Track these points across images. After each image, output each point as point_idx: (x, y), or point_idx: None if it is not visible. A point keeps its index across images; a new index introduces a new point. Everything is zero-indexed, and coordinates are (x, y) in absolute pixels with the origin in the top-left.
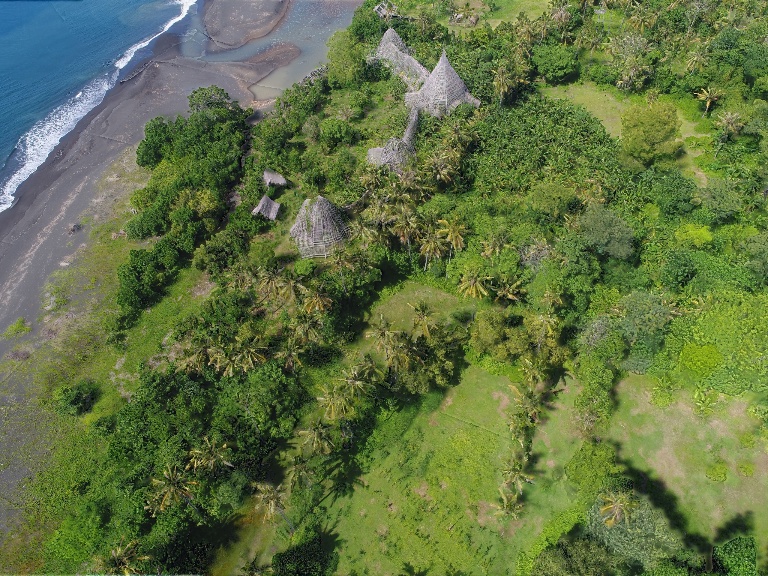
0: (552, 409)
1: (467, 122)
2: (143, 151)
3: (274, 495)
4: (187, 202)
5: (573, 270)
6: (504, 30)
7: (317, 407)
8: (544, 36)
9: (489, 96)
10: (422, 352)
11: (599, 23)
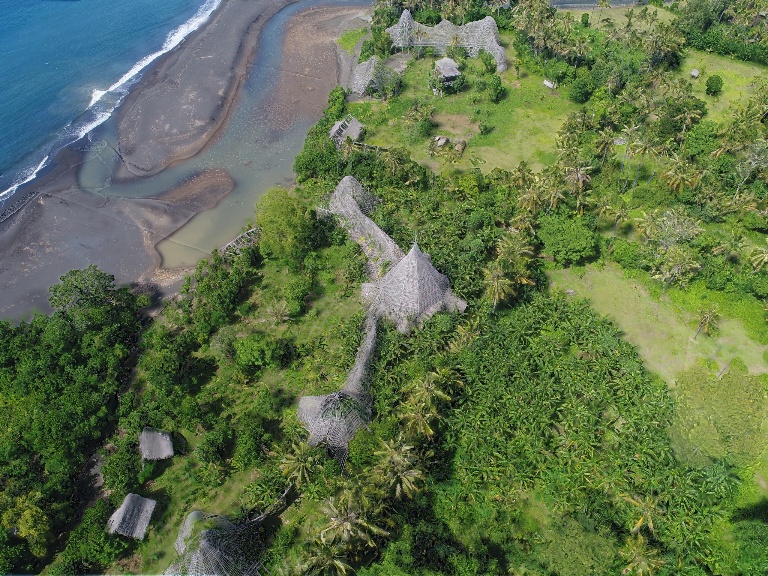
0: None
1: (447, 345)
2: None
3: None
4: (3, 511)
5: None
6: (499, 179)
7: None
8: (554, 206)
9: (478, 288)
10: None
11: (623, 173)
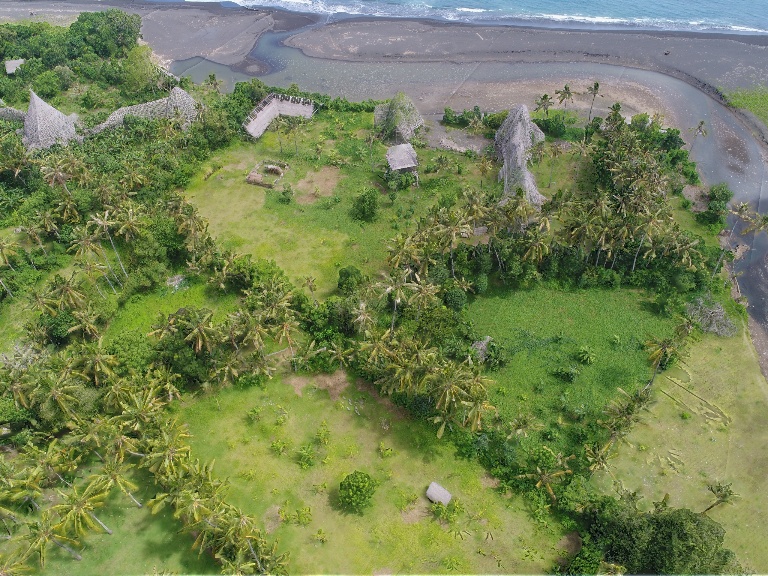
0: None
1: None
2: (81, 14)
3: None
4: None
5: None
6: None
7: None
8: None
9: None
10: None
11: None
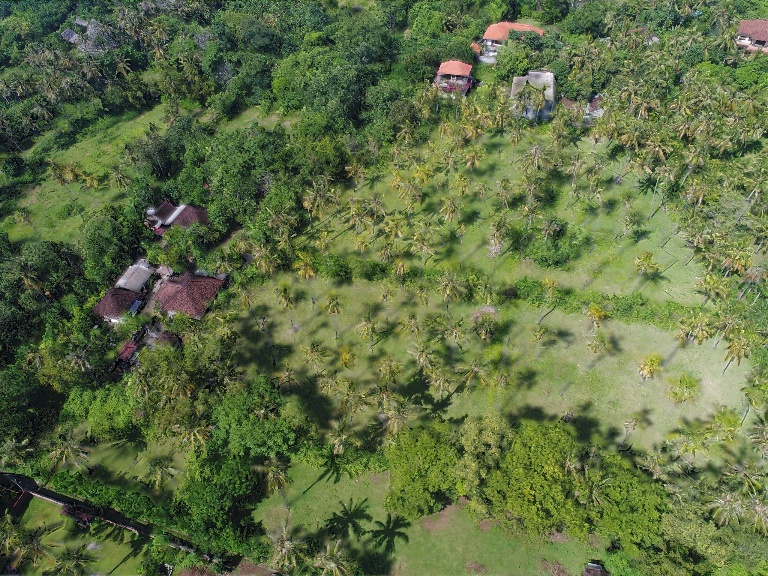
0: (199, 119)
1: None
2: None
3: (0, 116)
4: None
5: (221, 45)
6: None
7: (64, 120)
8: None
9: None
10: (121, 83)
11: None
